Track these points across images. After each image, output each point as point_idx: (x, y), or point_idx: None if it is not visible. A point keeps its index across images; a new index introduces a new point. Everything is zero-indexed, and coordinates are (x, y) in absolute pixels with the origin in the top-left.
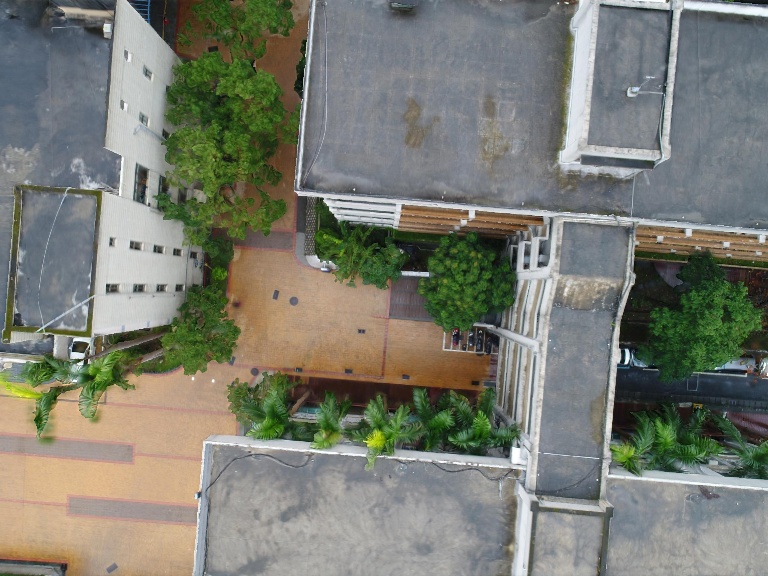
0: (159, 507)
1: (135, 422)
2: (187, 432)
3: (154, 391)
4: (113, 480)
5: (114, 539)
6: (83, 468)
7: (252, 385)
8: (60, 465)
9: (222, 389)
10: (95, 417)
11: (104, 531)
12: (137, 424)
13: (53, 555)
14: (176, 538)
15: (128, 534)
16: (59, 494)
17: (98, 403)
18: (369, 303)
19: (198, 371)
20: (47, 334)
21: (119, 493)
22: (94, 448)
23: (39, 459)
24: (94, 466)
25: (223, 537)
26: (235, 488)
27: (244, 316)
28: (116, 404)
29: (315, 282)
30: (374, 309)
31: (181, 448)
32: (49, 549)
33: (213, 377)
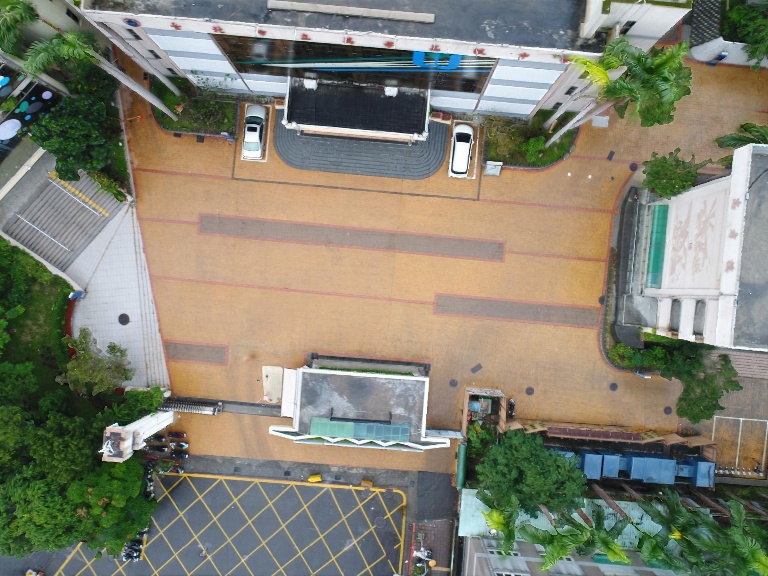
0: (527, 306)
1: (507, 219)
2: (560, 229)
3: (528, 187)
4: (482, 278)
5: (480, 339)
6: (452, 266)
7: (630, 181)
8: (430, 263)
9: (598, 185)
10: (467, 214)
11: (470, 331)
12: (509, 221)
13: (417, 355)
14: (543, 338)
15: (495, 334)
16: (427, 292)
17: (471, 199)
18: (753, 97)
19: (575, 166)
20: (641, 8)
21: (487, 292)
22: (465, 245)
23: (409, 256)
24: (464, 264)
25: (753, 249)
26: (767, 199)
27: (626, 110)
28: (489, 201)
29: (698, 76)
30: (758, 103)
31: (553, 246)
32: (414, 349)
33: (590, 173)
